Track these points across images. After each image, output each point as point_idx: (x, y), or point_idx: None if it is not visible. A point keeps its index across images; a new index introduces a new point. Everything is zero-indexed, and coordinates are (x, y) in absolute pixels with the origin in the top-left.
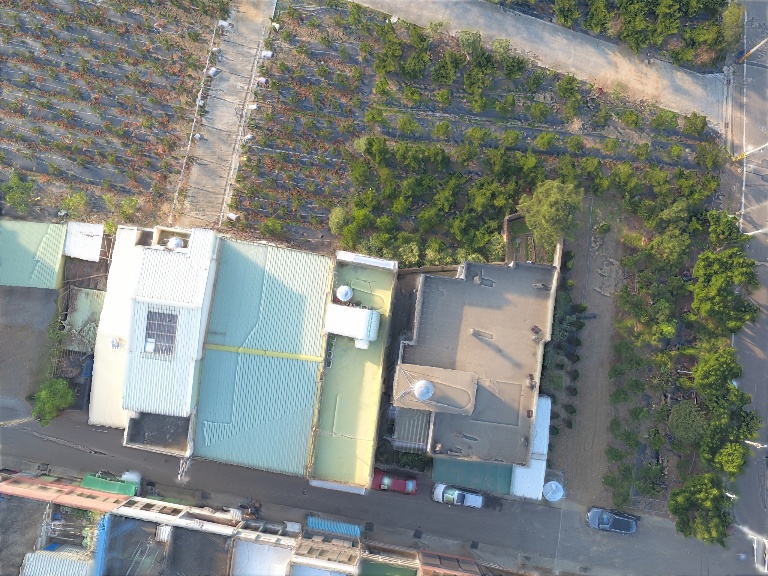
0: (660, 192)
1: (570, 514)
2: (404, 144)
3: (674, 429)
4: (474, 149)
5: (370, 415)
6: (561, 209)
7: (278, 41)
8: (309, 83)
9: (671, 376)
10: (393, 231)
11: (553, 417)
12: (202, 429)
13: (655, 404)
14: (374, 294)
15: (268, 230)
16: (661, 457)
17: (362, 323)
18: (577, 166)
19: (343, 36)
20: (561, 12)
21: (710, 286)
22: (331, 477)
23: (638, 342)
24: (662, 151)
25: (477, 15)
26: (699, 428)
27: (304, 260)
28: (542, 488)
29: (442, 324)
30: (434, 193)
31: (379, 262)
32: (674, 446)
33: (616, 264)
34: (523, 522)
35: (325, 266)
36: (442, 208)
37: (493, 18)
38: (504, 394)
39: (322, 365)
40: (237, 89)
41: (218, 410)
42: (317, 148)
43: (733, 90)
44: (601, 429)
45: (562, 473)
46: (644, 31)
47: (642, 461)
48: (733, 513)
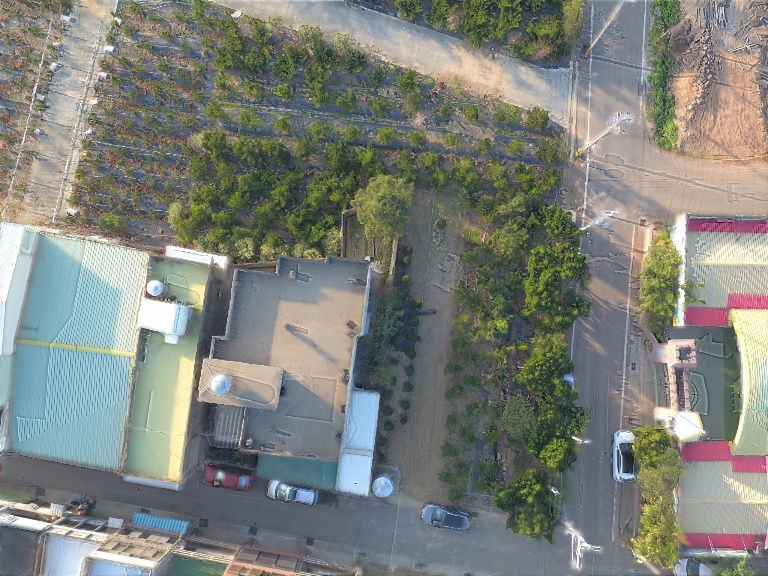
0: (499, 187)
1: (407, 511)
2: (241, 139)
3: (506, 425)
4: (313, 144)
5: (184, 410)
6: (389, 204)
7: (120, 36)
8: (151, 78)
9: (507, 372)
10: (232, 226)
11: (385, 413)
12: (15, 425)
13: (492, 400)
14: (190, 289)
15: (105, 225)
16: (499, 453)
17: (170, 318)
18: (420, 161)
19: (186, 31)
20: (403, 6)
21: (540, 281)
22: (144, 473)
23: (475, 338)
24: (505, 146)
25: (321, 10)
26: (526, 424)
27: (122, 255)
28: (368, 484)
29: (257, 319)
30: (273, 188)
31: (196, 257)
32: (509, 442)
33: (457, 259)
34: (359, 519)
35: (142, 261)
36: (278, 203)
37: (337, 13)
38: (318, 389)
39: (134, 360)
40: (78, 84)
41: (31, 405)
42: (158, 143)
43: (578, 85)
44: (439, 425)
45: (399, 469)
46: (486, 25)
47: (479, 457)
48: (561, 509)
